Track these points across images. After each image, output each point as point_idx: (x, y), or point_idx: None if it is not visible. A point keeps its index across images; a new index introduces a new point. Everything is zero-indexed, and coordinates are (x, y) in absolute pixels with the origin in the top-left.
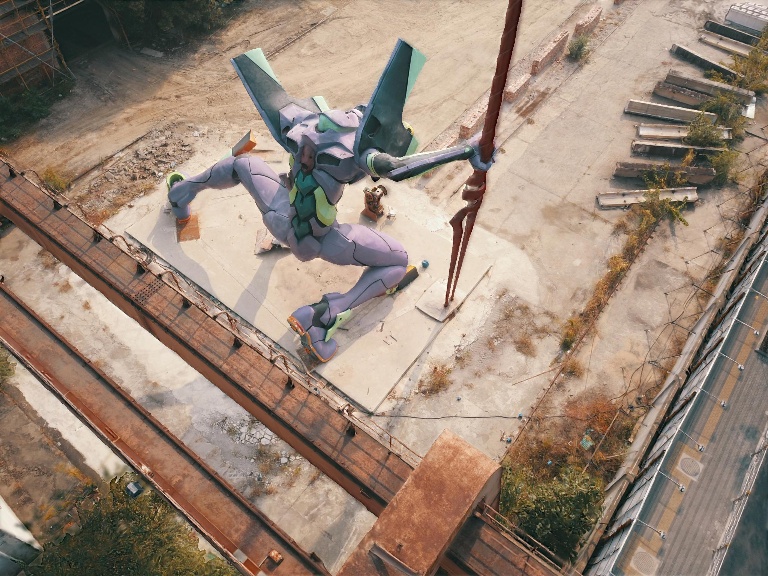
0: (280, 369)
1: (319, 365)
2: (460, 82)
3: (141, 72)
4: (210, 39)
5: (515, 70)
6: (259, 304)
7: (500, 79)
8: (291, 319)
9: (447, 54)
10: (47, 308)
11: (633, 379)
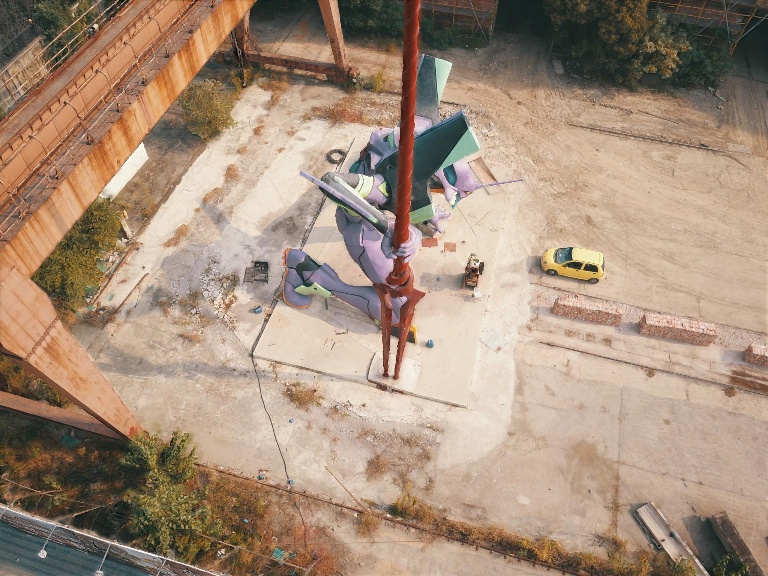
0: (25, 142)
1: (283, 301)
2: (734, 298)
3: (530, 71)
4: (609, 90)
5: None
6: (326, 241)
7: (399, 174)
8: (287, 249)
9: None
10: (271, 133)
11: None
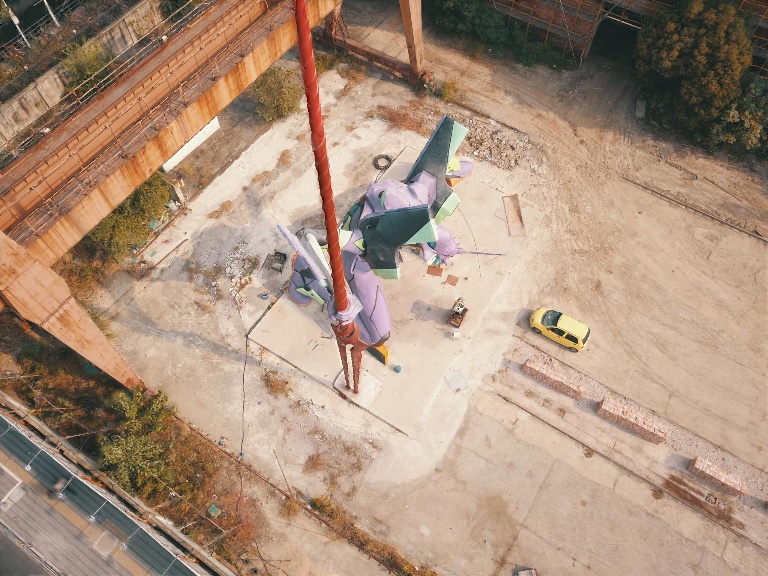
0: None
1: None
2: (709, 404)
3: (608, 108)
4: (683, 146)
5: (767, 479)
6: None
7: None
8: (297, 254)
9: (765, 387)
10: (332, 124)
11: (278, 570)
